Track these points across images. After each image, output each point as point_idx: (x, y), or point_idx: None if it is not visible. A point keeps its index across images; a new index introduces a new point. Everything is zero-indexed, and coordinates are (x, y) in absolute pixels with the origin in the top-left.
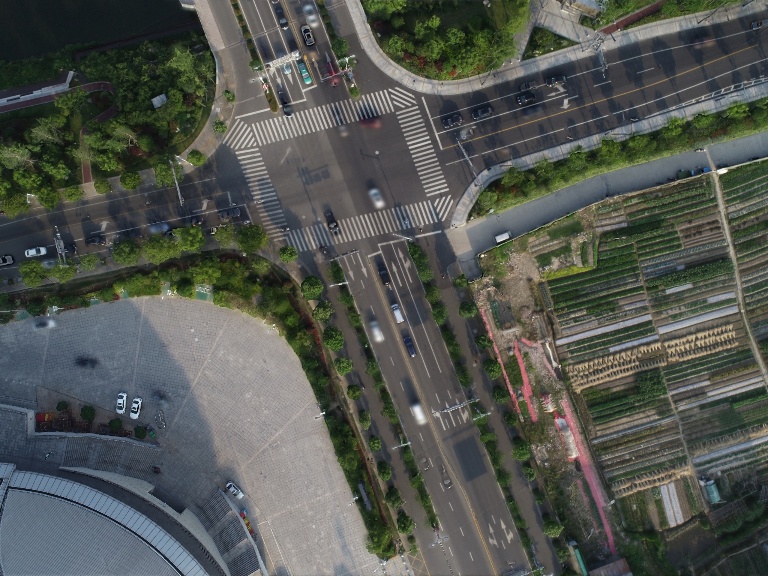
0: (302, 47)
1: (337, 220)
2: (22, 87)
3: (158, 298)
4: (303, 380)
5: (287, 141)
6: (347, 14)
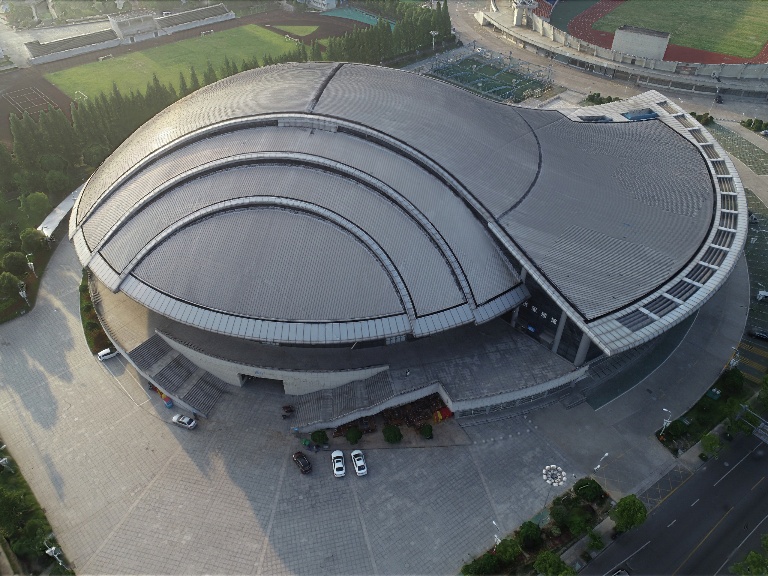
0: None
1: None
2: None
3: None
4: None
5: None
6: None
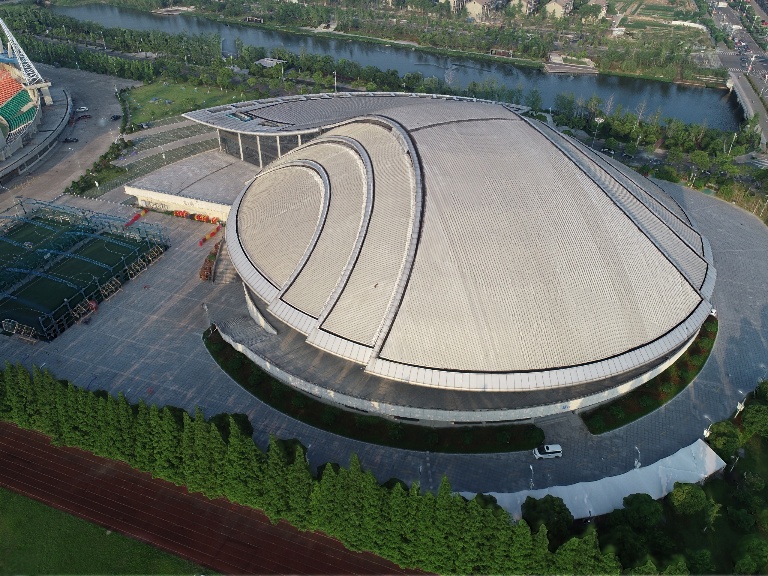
0: None
1: None
2: None
3: (674, 184)
4: None
5: None
6: None
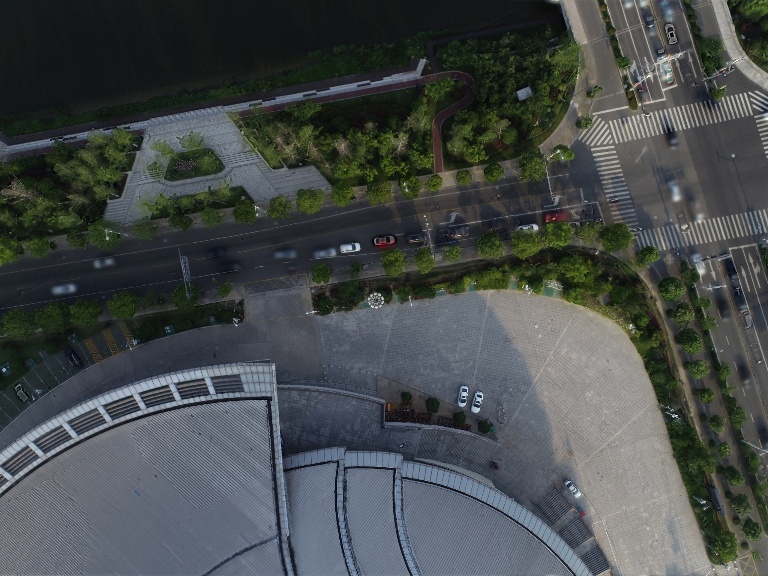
0: (666, 46)
1: (689, 222)
2: (371, 73)
3: (503, 292)
4: (645, 381)
5: (644, 140)
6: (711, 14)
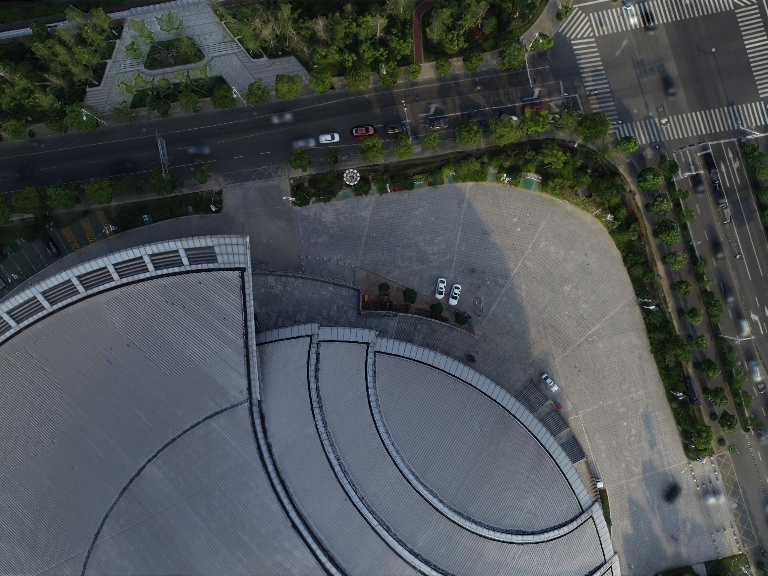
0: None
1: (669, 116)
2: None
3: (482, 185)
4: (623, 276)
5: (624, 33)
6: None
